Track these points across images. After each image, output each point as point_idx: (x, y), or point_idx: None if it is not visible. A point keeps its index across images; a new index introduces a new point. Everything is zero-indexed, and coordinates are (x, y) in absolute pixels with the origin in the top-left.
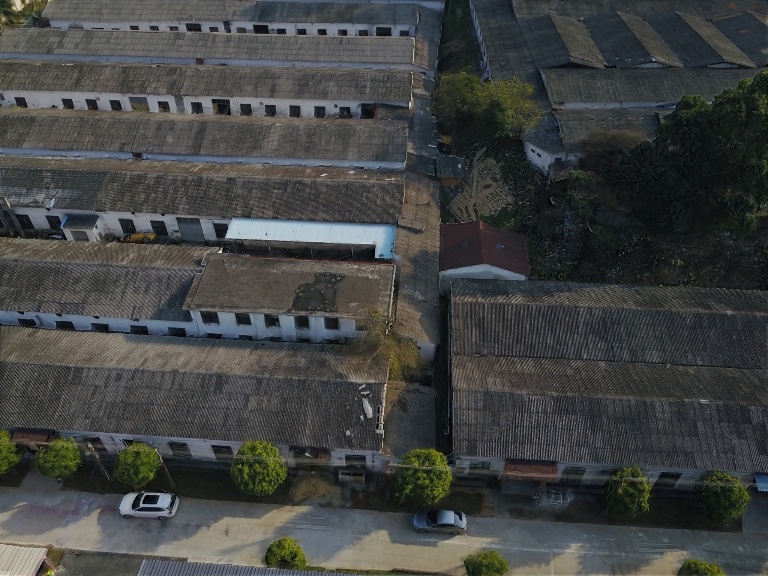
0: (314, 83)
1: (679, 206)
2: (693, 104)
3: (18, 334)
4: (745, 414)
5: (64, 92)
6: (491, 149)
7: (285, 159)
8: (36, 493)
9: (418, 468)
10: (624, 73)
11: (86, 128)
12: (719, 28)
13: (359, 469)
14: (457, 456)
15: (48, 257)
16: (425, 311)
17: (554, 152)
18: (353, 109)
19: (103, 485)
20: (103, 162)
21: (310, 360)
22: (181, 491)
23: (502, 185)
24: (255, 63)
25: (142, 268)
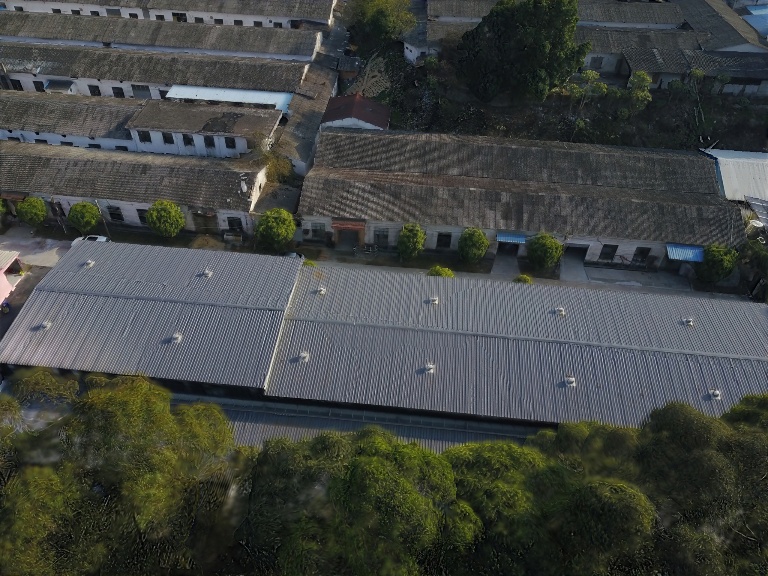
0: (254, 3)
1: (491, 76)
2: (506, 3)
3: (7, 143)
4: (498, 196)
5: (54, 3)
6: (381, 51)
7: (221, 51)
8: (15, 238)
9: (269, 215)
10: None
11: (68, 24)
12: None
13: (239, 232)
14: (301, 217)
15: (32, 97)
16: (302, 143)
17: (419, 46)
18: (284, 24)
19: (61, 236)
20: (79, 47)
21: (211, 163)
22: (115, 241)
23: (384, 75)
24: None
25: (99, 105)
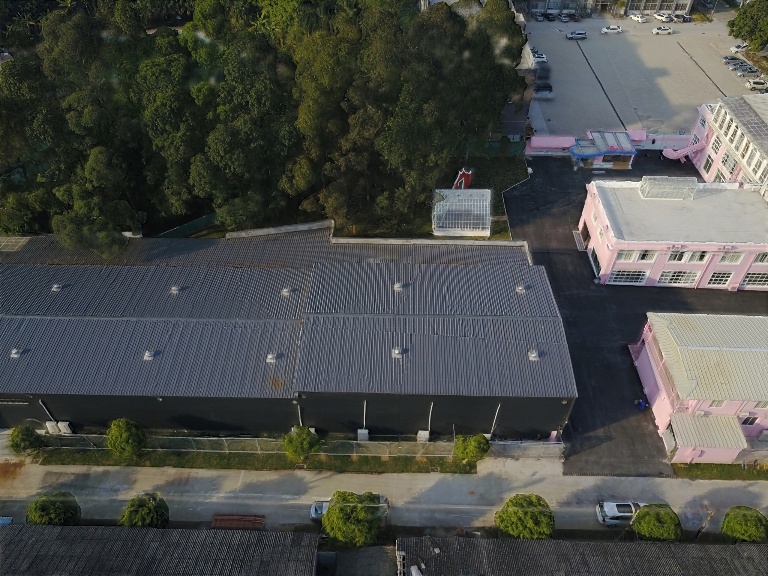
0: None
1: None
2: None
3: None
4: None
5: None
6: None
7: None
8: None
9: None
10: None
11: None
12: None
13: None
14: None
15: None
16: None
17: None
18: None
19: (690, 539)
20: None
21: None
22: (605, 535)
23: None
24: None
25: None
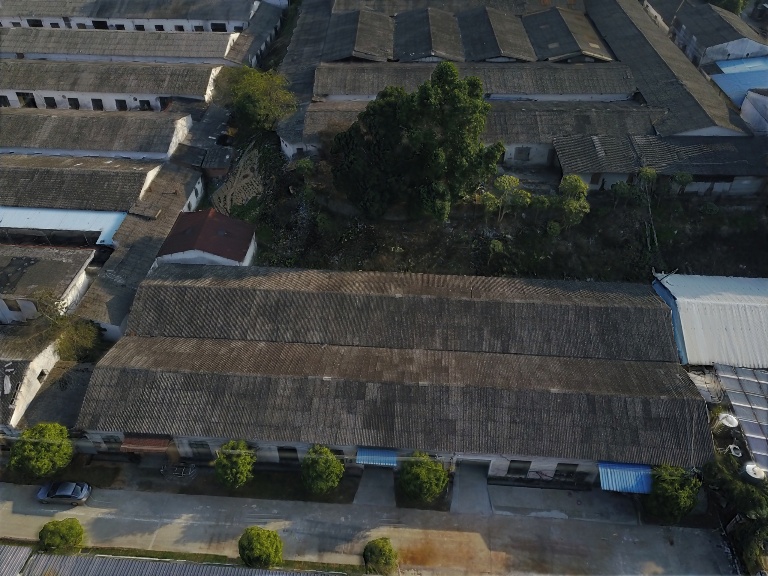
0: (115, 77)
1: (372, 193)
2: (389, 94)
3: None
4: (361, 390)
5: None
6: (257, 140)
7: (53, 150)
8: None
9: (26, 440)
10: (395, 66)
11: None
12: (524, 24)
13: None
14: (83, 430)
15: None
16: (119, 294)
17: (293, 142)
18: (152, 102)
19: None
20: None
21: None
22: None
23: (257, 175)
24: (73, 58)
25: None
